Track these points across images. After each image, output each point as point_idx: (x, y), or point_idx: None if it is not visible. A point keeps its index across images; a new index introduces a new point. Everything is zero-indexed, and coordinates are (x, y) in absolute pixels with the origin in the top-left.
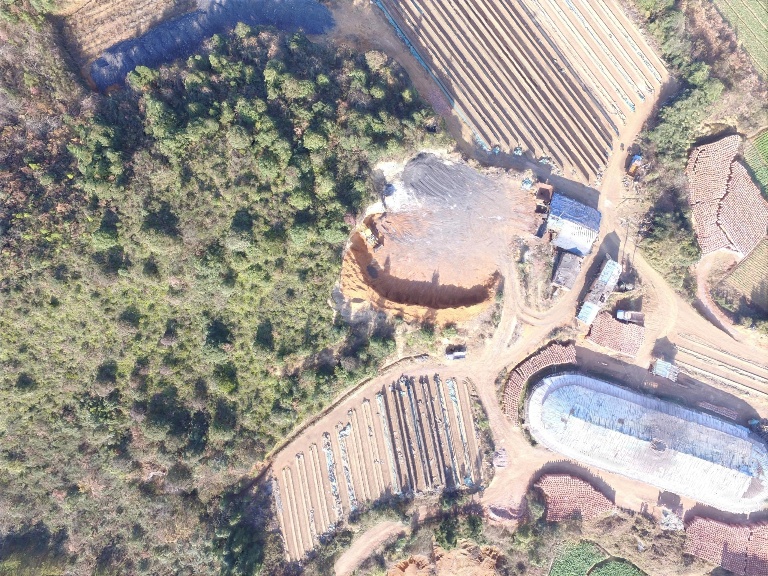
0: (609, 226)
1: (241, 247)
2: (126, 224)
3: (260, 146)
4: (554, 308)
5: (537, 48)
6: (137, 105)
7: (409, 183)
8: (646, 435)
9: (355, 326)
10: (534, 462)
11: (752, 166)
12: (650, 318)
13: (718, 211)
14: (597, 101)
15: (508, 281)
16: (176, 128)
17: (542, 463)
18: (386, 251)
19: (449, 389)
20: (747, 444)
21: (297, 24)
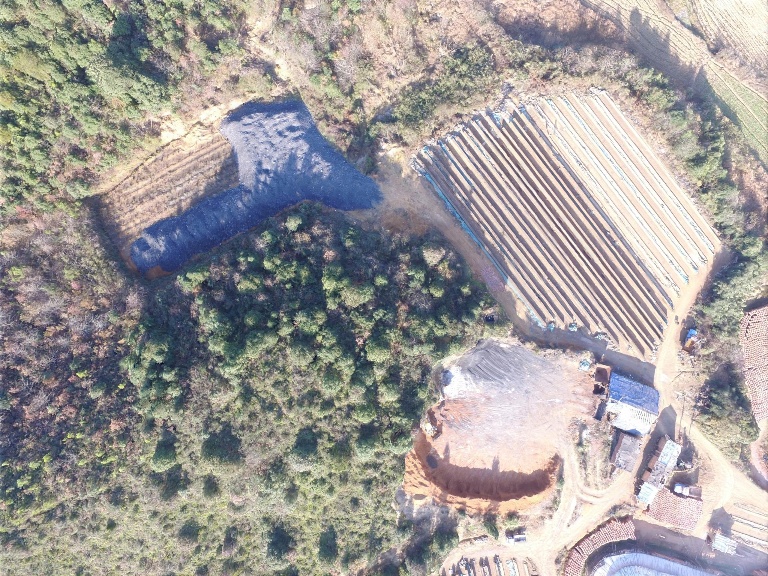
0: (665, 400)
1: (307, 469)
2: (184, 443)
3: (322, 362)
4: (613, 485)
5: (590, 221)
6: (188, 309)
7: (466, 368)
8: None
9: (418, 523)
10: None
11: None
12: (707, 489)
13: None
14: (651, 273)
15: (567, 463)
16: (236, 350)
17: None
18: (445, 439)
19: (509, 570)
20: None
21: (345, 200)
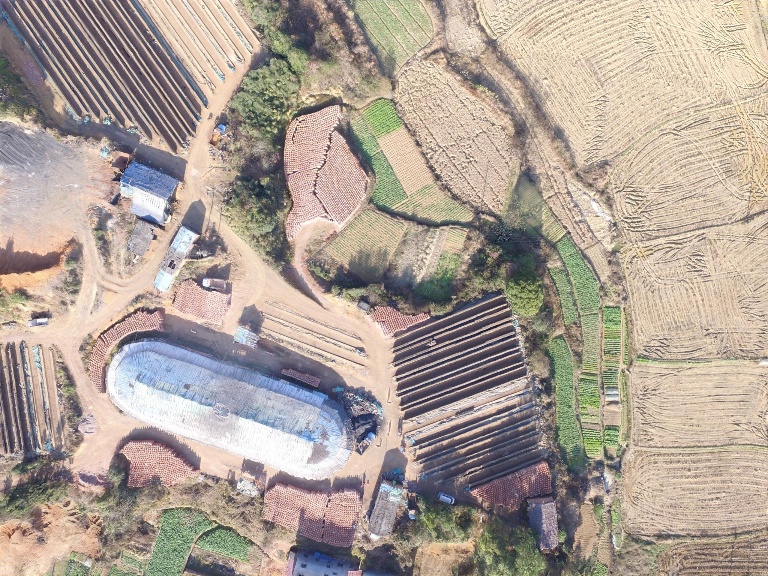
0: (195, 194)
1: None
2: None
3: None
4: (138, 275)
5: (128, 19)
6: None
7: None
8: (210, 400)
9: None
10: (122, 429)
11: (359, 137)
12: (238, 286)
13: (316, 180)
14: (188, 71)
15: (87, 248)
16: None
17: (129, 430)
18: None
19: (34, 356)
20: (315, 410)
21: None
